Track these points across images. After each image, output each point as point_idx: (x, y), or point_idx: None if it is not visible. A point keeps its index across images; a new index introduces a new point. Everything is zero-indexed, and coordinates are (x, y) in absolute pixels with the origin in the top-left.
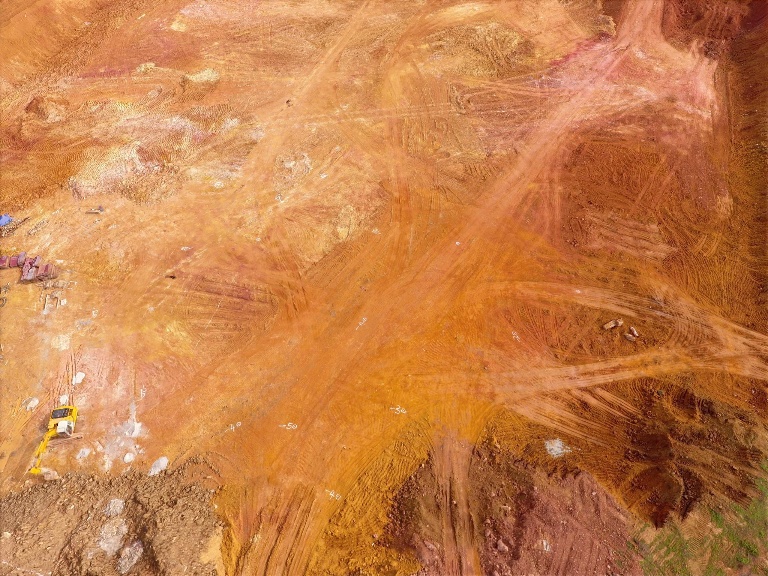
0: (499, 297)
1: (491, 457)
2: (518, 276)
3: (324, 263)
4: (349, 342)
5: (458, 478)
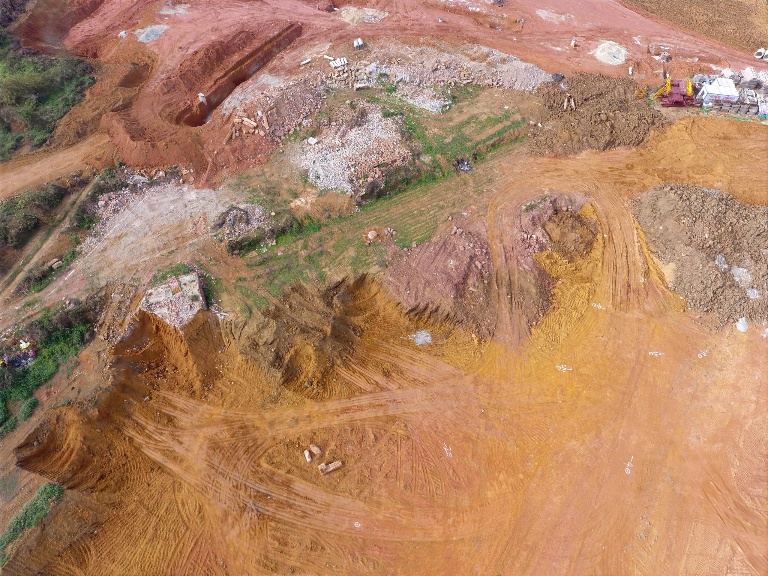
0: (466, 510)
1: (479, 330)
2: (437, 551)
3: (717, 571)
4: (635, 439)
5: (506, 314)
